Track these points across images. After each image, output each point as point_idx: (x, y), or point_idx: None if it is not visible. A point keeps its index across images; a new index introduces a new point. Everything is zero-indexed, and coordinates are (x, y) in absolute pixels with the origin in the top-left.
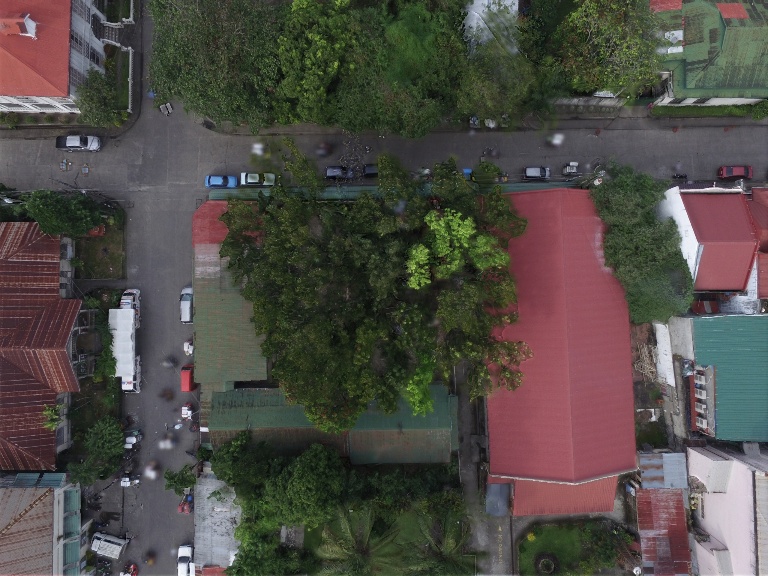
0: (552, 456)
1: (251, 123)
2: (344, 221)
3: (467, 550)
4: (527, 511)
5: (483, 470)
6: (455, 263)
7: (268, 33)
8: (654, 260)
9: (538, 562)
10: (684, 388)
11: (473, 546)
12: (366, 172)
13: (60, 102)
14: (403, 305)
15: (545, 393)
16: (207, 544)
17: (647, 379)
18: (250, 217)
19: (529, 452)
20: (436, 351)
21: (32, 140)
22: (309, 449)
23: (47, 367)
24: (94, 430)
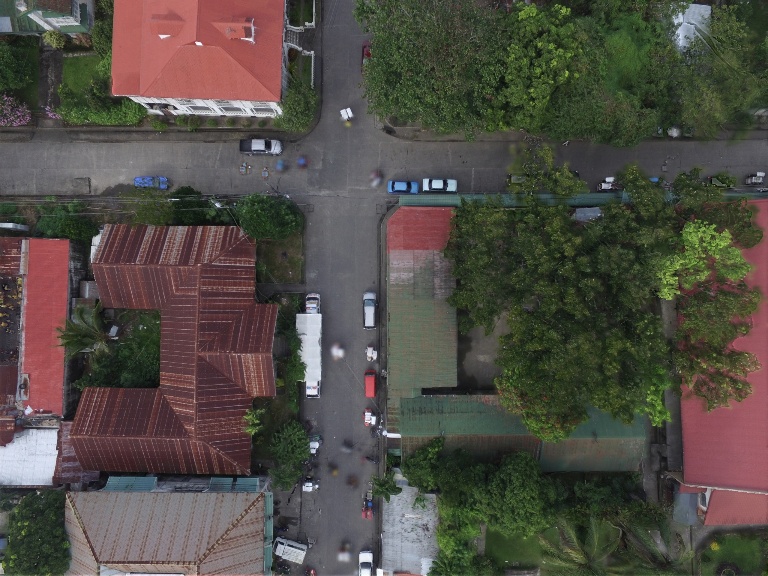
0: (755, 467)
1: (466, 130)
2: (596, 231)
3: None
4: (719, 521)
5: (664, 479)
6: (705, 274)
7: (498, 41)
8: None
9: (721, 572)
10: None
11: None
12: None
13: (256, 106)
14: (649, 316)
15: (748, 404)
16: (397, 550)
17: None
18: (500, 226)
19: (729, 462)
20: (679, 362)
21: (211, 143)
22: (518, 457)
23: (249, 372)
24: (283, 435)
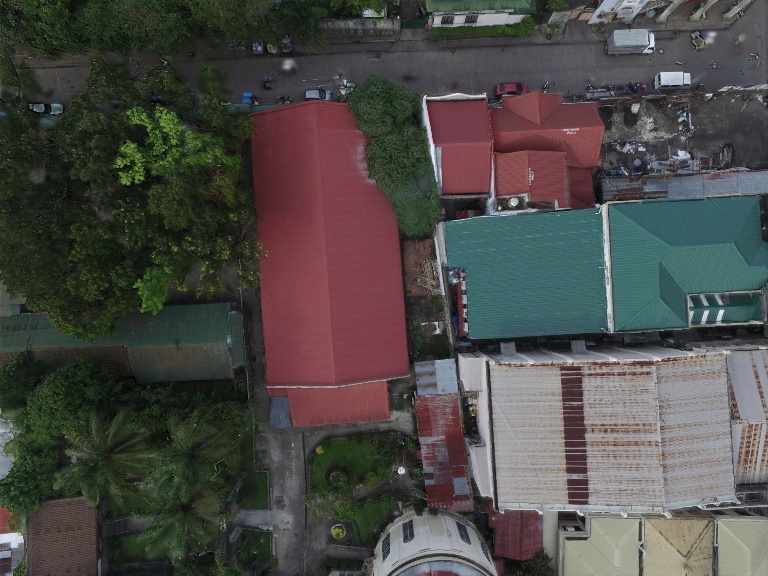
0: (316, 362)
1: (2, 43)
2: (55, 121)
3: (259, 466)
4: (306, 421)
5: None
6: (167, 159)
7: None
8: (404, 167)
9: (328, 475)
10: (448, 294)
11: (266, 462)
12: None
13: None
14: (121, 203)
15: (309, 302)
16: None
17: (431, 293)
18: None
19: (298, 361)
20: (157, 248)
21: None
22: None
23: None
24: None
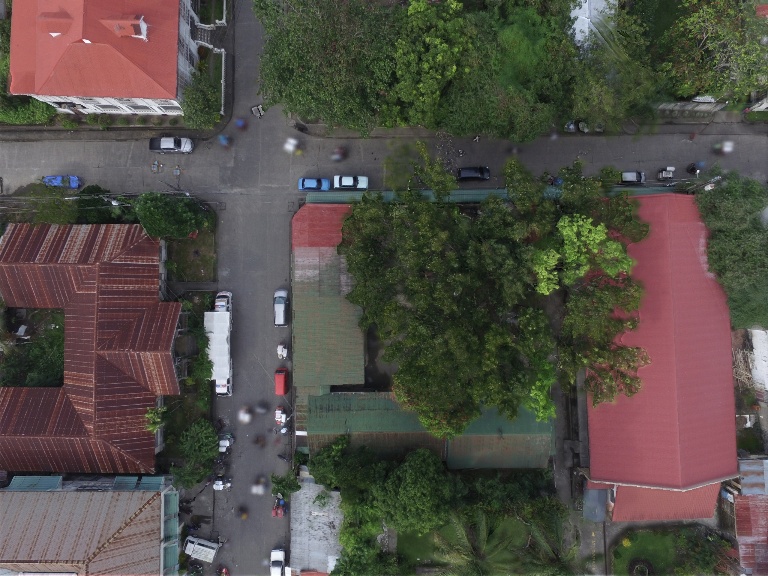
0: (658, 462)
1: (361, 126)
2: (474, 226)
3: None
4: (626, 517)
5: (577, 475)
6: (584, 269)
7: (386, 36)
8: (763, 266)
9: (633, 568)
10: None
11: None
12: (462, 176)
13: (160, 104)
14: (530, 310)
15: (650, 399)
16: (304, 548)
17: (742, 385)
18: (378, 221)
19: (633, 458)
20: (562, 357)
21: (123, 142)
22: (416, 454)
23: (150, 370)
24: (190, 433)
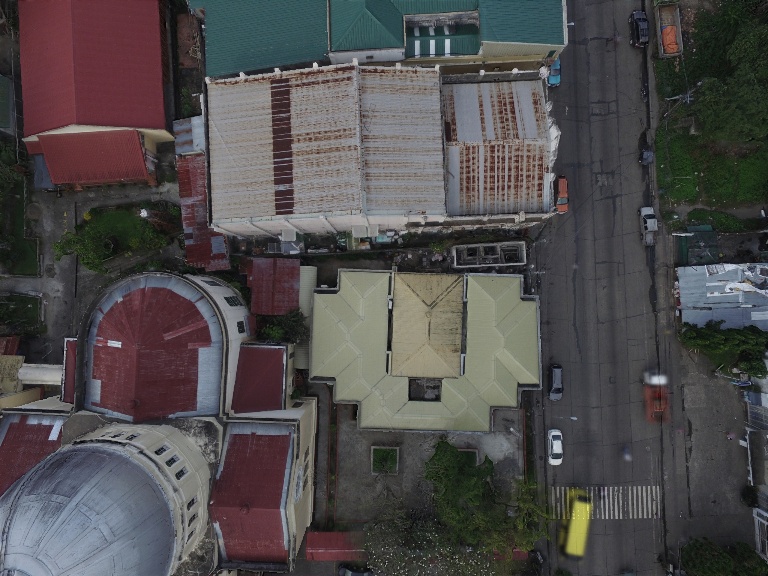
0: (62, 106)
1: None
2: None
3: (30, 233)
4: (64, 178)
5: None
6: None
7: None
8: None
9: None
10: None
11: (38, 231)
12: None
13: None
14: None
15: (57, 48)
16: None
17: None
18: None
19: (48, 109)
20: None
21: None
22: None
23: None
24: None
